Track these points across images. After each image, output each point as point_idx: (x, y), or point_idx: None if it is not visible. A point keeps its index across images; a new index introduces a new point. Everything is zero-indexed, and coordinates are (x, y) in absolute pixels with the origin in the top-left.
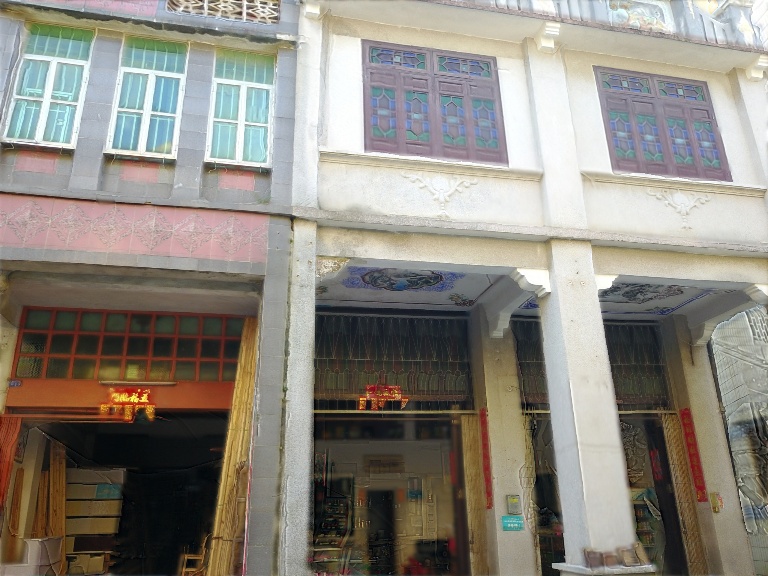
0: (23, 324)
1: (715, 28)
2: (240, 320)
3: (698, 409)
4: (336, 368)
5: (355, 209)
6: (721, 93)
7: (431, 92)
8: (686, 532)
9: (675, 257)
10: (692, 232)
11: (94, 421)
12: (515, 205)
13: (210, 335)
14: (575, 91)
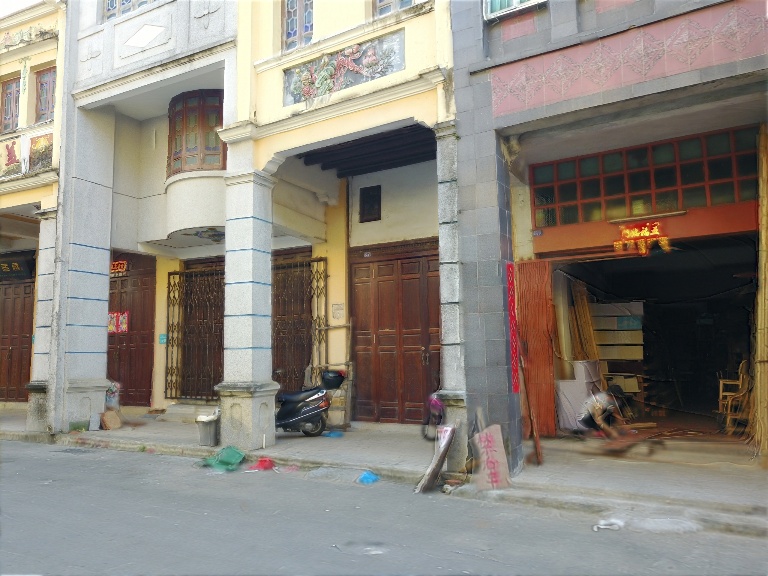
0: (532, 181)
1: None
2: (751, 130)
3: None
4: None
5: None
6: None
7: None
8: None
9: None
10: None
11: (609, 258)
12: None
13: (716, 154)
14: None
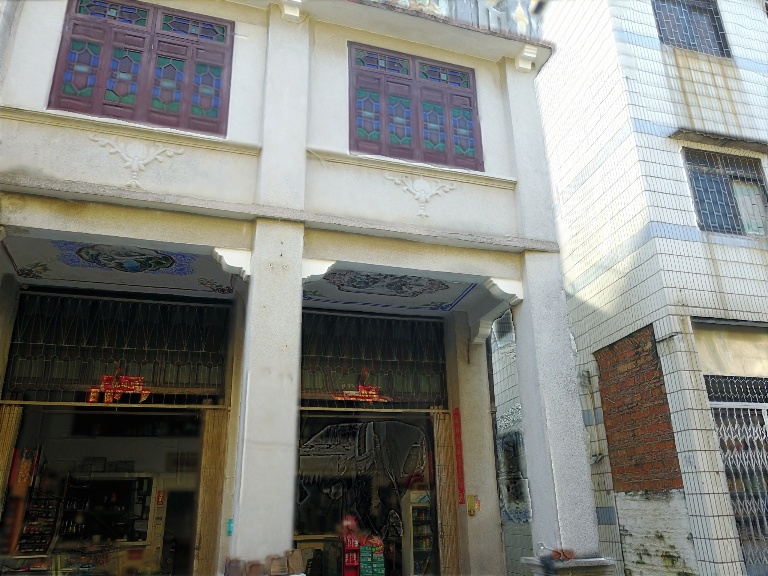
0: None
1: (490, 15)
2: None
3: (467, 408)
4: (65, 355)
5: (21, 171)
6: (488, 82)
7: (147, 51)
8: (443, 536)
9: (404, 245)
10: (428, 220)
11: None
12: (225, 180)
13: None
14: (322, 65)
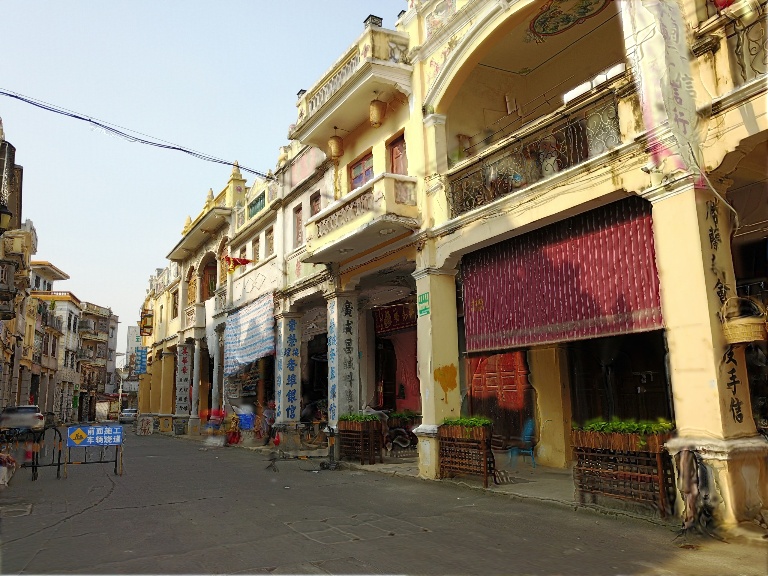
0: None
1: None
2: None
3: None
4: None
5: None
6: None
7: None
8: None
9: None
10: None
11: None
12: None
13: None
14: None
